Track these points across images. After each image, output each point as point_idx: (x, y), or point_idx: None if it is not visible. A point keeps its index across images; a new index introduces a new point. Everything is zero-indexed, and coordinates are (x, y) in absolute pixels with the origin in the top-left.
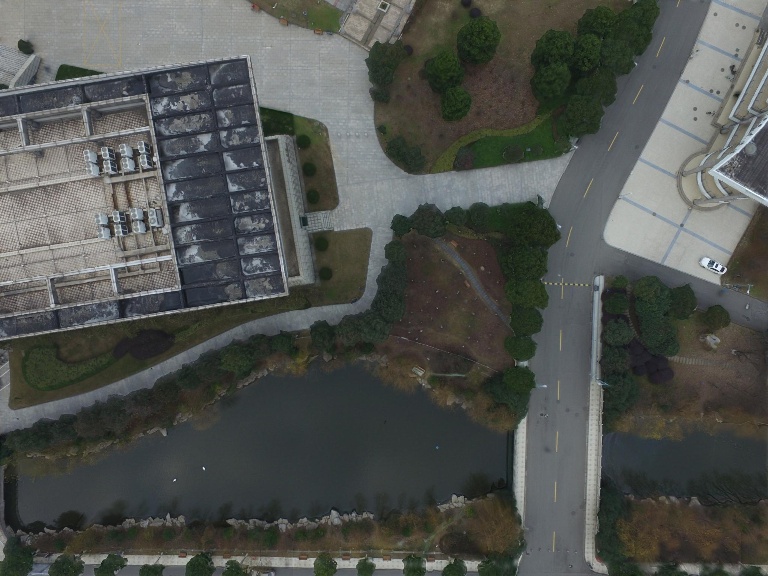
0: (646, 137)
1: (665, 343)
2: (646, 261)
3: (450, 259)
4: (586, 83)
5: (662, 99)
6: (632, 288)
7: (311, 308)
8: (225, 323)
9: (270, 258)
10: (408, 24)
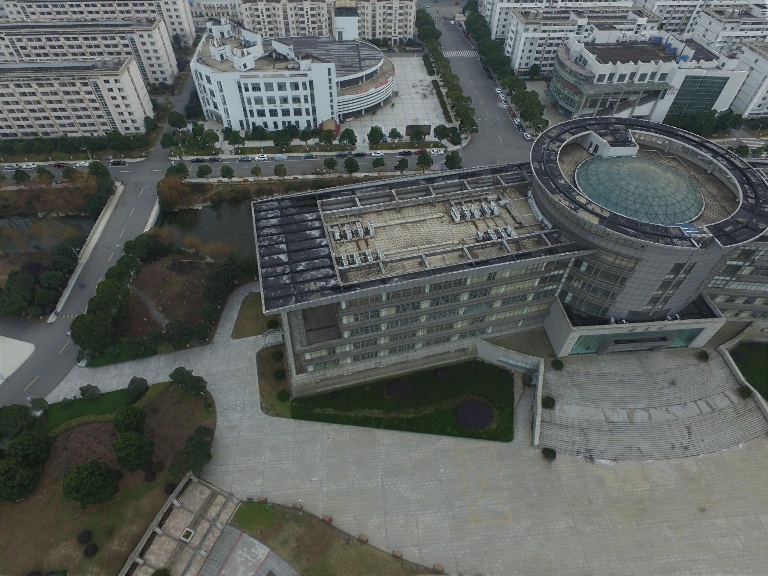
0: None
1: (18, 273)
2: (6, 335)
3: None
4: None
5: None
6: None
7: None
8: None
9: None
10: (164, 519)
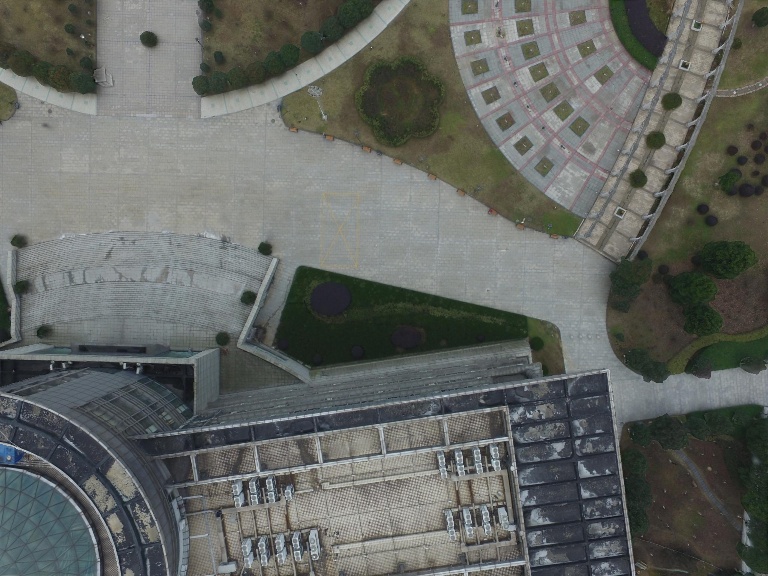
0: None
1: None
2: None
3: (677, 459)
4: None
5: None
6: None
7: None
8: None
9: (619, 562)
10: (643, 229)
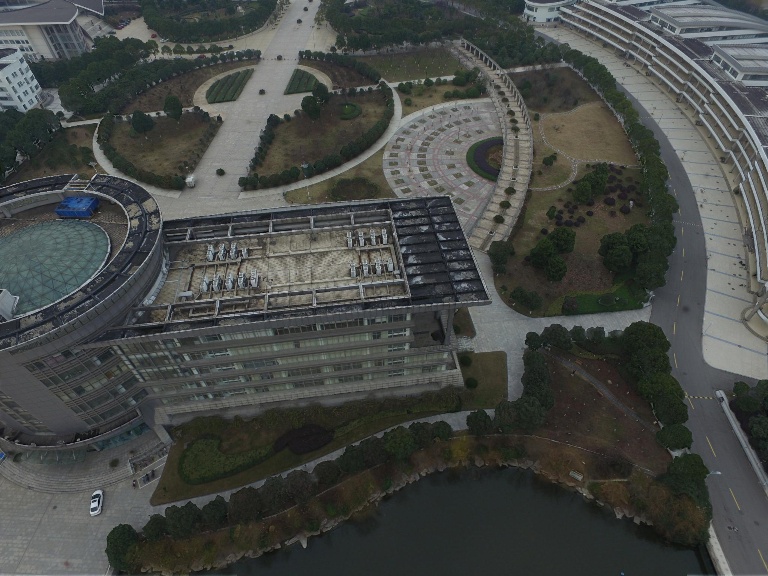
0: (702, 299)
1: None
2: (754, 380)
3: (578, 375)
4: (644, 257)
5: (701, 278)
6: (755, 392)
7: (461, 412)
8: (381, 423)
9: (474, 283)
10: None
